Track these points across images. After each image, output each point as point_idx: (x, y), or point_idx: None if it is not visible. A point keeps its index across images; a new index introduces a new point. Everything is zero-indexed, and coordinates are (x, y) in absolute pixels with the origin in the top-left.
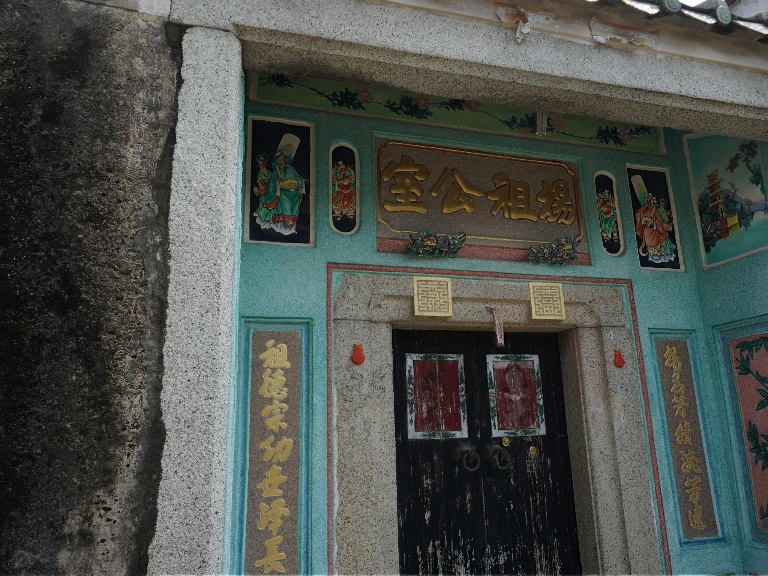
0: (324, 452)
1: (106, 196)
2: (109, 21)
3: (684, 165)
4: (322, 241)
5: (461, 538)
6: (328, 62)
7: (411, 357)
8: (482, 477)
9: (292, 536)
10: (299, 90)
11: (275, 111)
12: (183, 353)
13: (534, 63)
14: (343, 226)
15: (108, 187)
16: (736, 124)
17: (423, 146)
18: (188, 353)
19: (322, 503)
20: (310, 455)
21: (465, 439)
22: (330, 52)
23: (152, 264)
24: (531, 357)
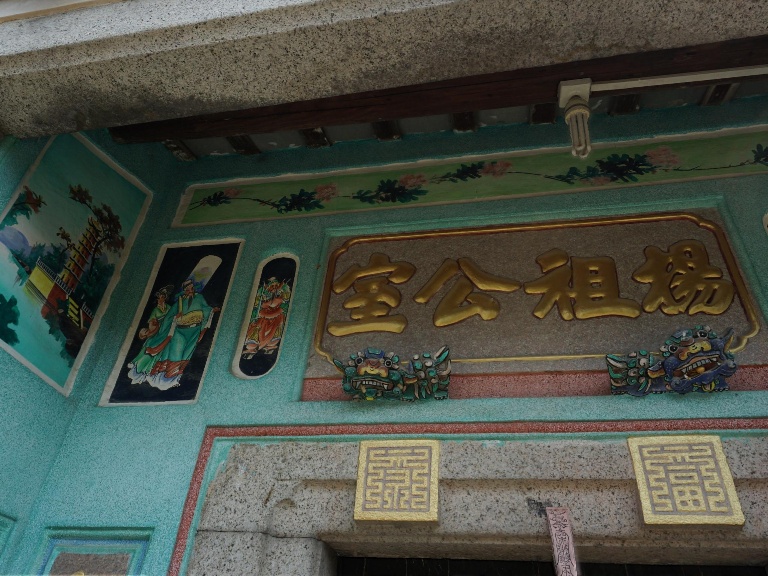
0: None
1: None
2: None
3: None
4: (209, 392)
5: None
6: (88, 84)
7: None
8: None
9: None
10: (237, 204)
11: (197, 232)
12: None
13: None
14: (254, 367)
15: None
16: None
17: (408, 236)
18: None
19: None
20: None
21: None
22: (74, 63)
23: None
24: None
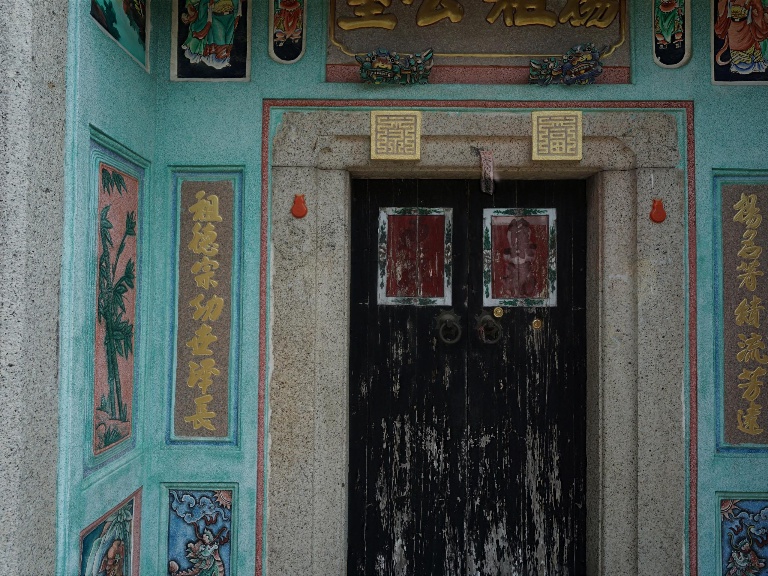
0: (255, 313)
1: None
2: None
3: None
4: (258, 73)
5: (435, 415)
6: None
7: (385, 211)
8: (466, 351)
9: (222, 396)
10: None
11: None
12: None
13: None
14: (286, 53)
15: None
16: None
17: None
18: None
19: (252, 366)
20: (241, 316)
21: (448, 307)
22: None
23: None
24: (545, 211)
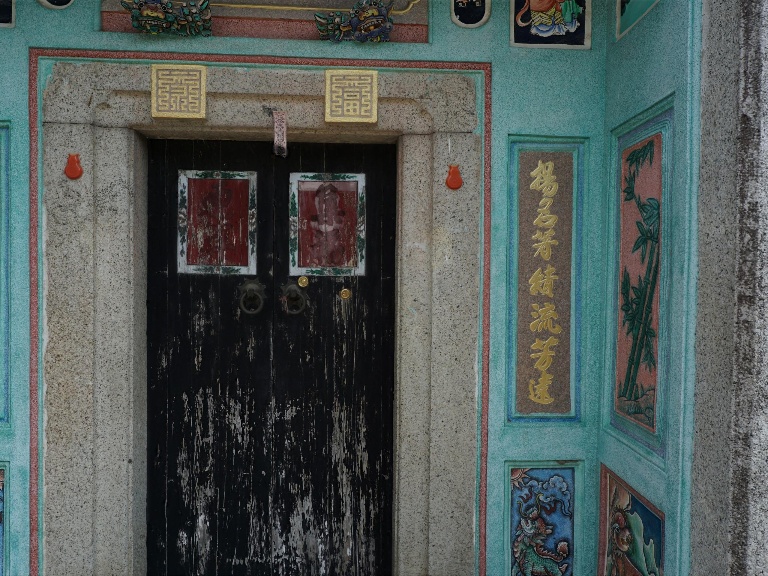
0: (25, 281)
1: None
2: None
3: None
4: (23, 18)
5: (239, 387)
6: None
7: (186, 174)
8: (271, 321)
9: None
10: None
11: None
12: None
13: None
14: None
15: None
16: None
17: None
18: None
19: (22, 338)
20: (9, 284)
21: (252, 276)
22: None
23: None
24: (355, 177)
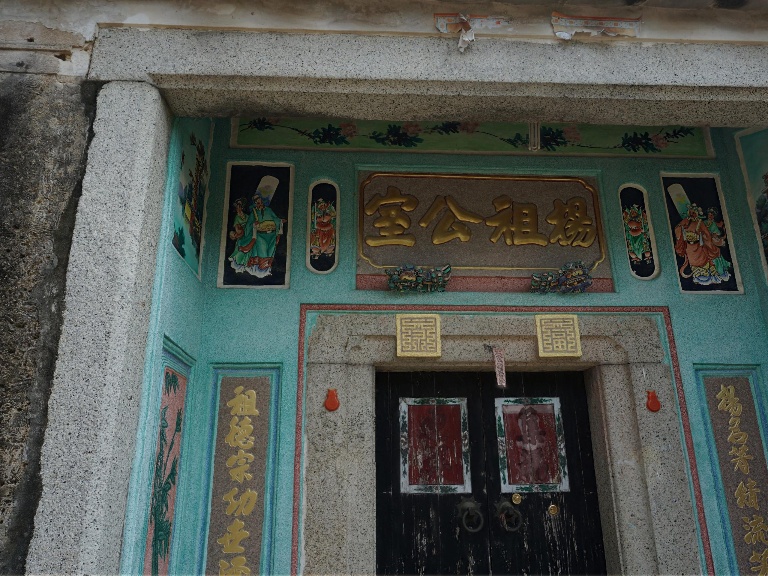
0: (289, 507)
1: (10, 252)
2: (30, 87)
3: (738, 167)
4: (296, 282)
5: None
6: (253, 99)
7: (406, 402)
8: (488, 539)
9: None
10: (280, 131)
11: (254, 155)
12: (67, 405)
13: (481, 72)
14: (321, 265)
15: (13, 243)
16: (764, 111)
17: (412, 175)
18: (71, 405)
19: (284, 563)
20: (274, 509)
21: (468, 494)
22: (250, 89)
23: (46, 316)
24: (550, 400)
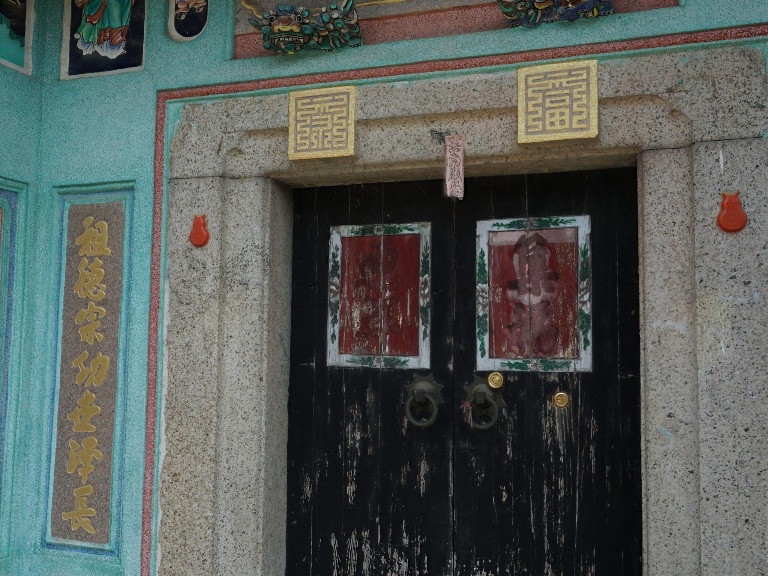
0: (142, 377)
1: None
2: None
3: None
4: (152, 58)
5: (405, 534)
6: None
7: (339, 232)
8: (451, 438)
9: (103, 488)
10: None
11: None
12: None
13: None
14: (188, 27)
15: None
16: None
17: None
18: None
19: (136, 449)
20: (126, 380)
21: (424, 371)
22: None
23: None
24: (573, 220)
